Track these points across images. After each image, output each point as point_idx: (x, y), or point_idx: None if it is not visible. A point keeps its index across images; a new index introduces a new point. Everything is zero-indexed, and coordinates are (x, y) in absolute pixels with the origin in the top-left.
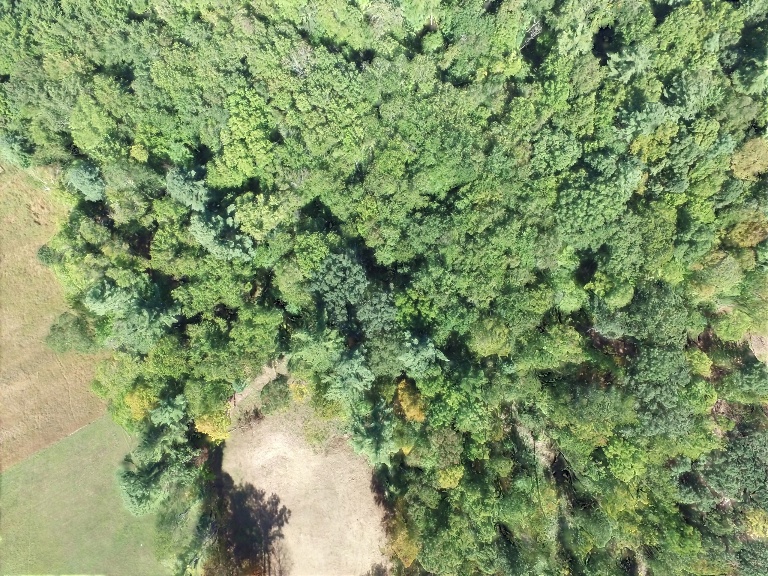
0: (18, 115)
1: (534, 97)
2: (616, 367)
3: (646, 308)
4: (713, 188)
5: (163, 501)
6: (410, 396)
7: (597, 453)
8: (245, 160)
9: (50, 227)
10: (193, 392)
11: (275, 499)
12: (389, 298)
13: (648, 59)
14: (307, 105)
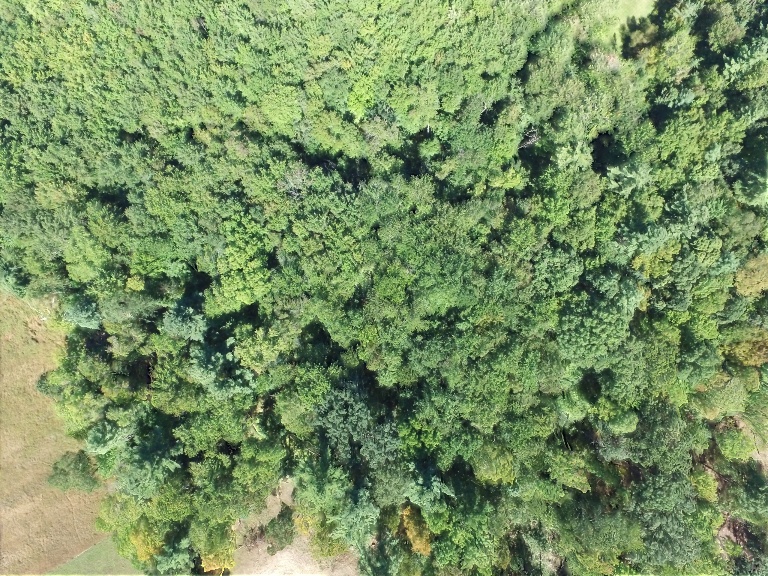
0: (11, 243)
1: (534, 211)
2: (621, 487)
3: (651, 437)
4: (716, 306)
5: None
6: (416, 527)
7: None
8: (243, 293)
9: (48, 345)
10: (198, 536)
11: None
12: (392, 428)
13: (649, 174)
14: (304, 232)
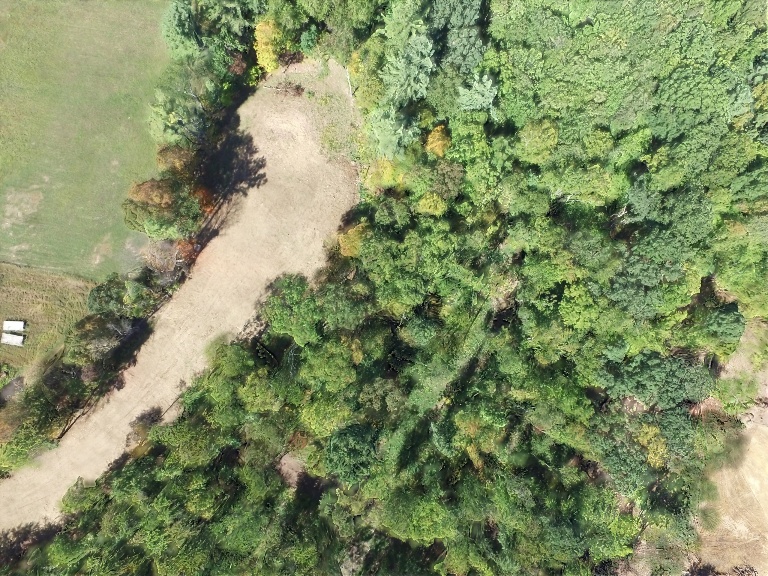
0: None
1: None
2: None
3: (683, 199)
4: None
5: (190, 56)
6: (442, 134)
7: (557, 289)
8: None
9: None
10: None
11: (262, 163)
12: (482, 48)
13: None
14: None
